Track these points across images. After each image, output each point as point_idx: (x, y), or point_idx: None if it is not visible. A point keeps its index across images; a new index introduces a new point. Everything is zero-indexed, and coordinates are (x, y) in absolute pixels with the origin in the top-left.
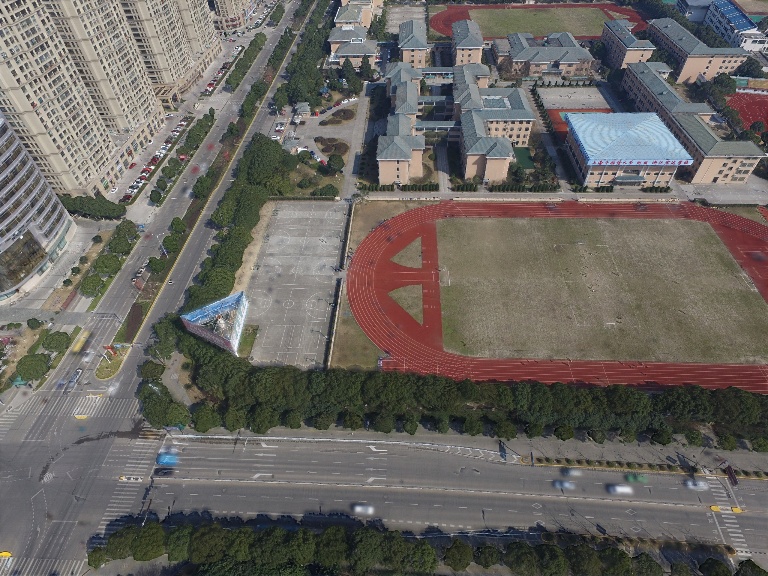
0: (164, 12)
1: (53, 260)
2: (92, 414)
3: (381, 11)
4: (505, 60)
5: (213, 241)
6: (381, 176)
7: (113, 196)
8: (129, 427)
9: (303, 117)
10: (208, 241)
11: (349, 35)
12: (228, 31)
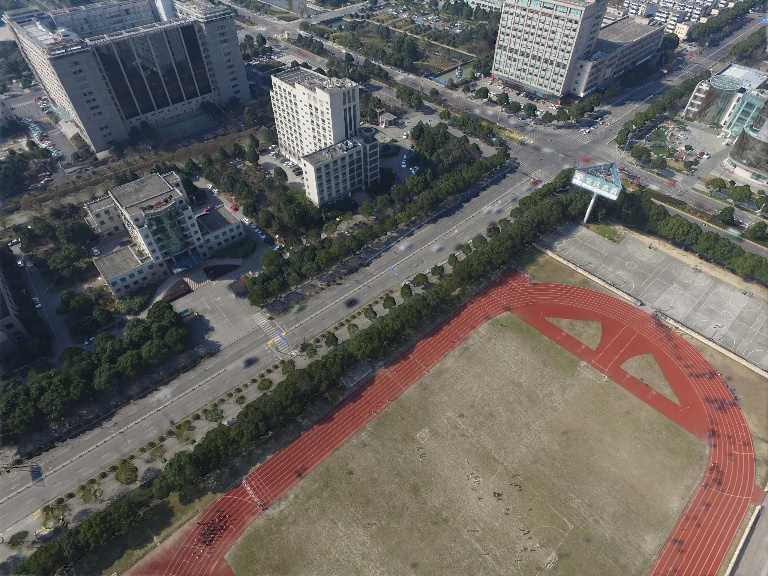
0: None
1: None
2: None
3: None
4: None
5: None
6: None
7: None
8: None
9: None
10: None
11: None
12: None
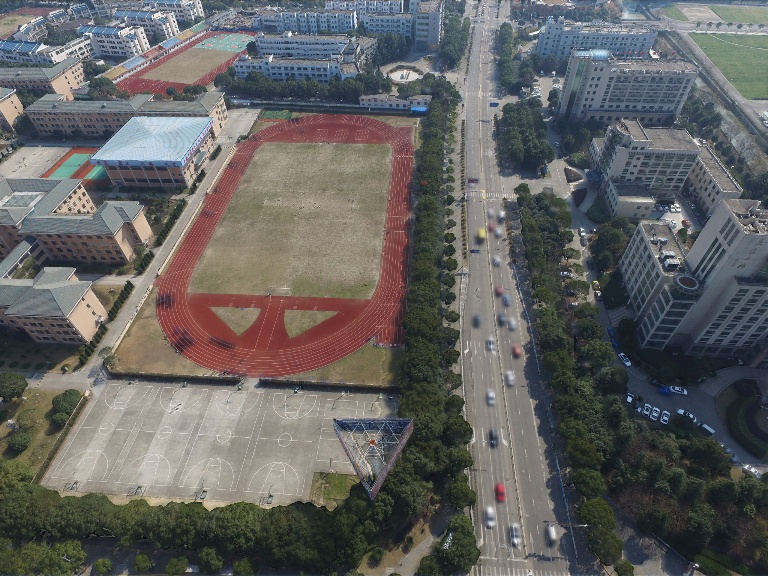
0: None
1: None
2: None
3: None
4: None
5: None
6: (81, 331)
7: None
8: None
9: None
10: None
11: None
12: None
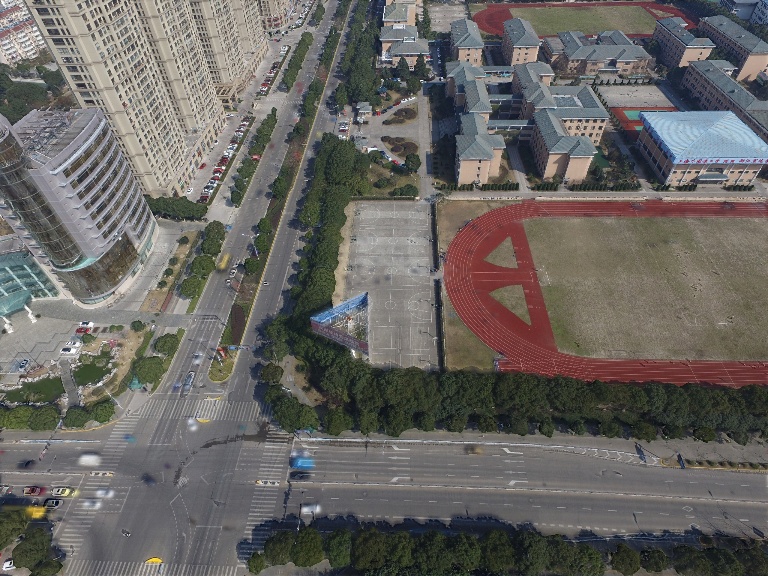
0: (224, 11)
1: (142, 261)
2: (214, 417)
3: (421, 10)
4: (560, 58)
5: (300, 242)
6: (461, 175)
7: (189, 197)
8: (254, 430)
9: (365, 116)
10: (295, 242)
11: (401, 34)
12: (270, 31)
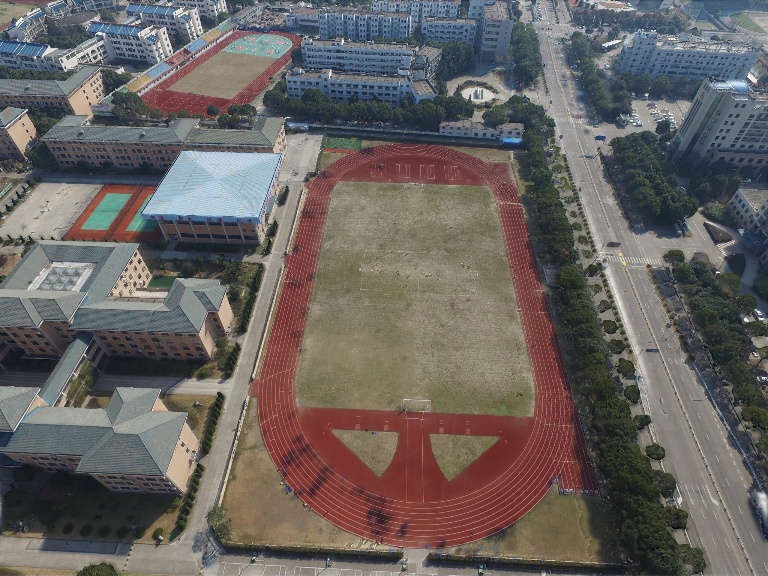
0: None
1: None
2: None
3: None
4: None
5: None
6: (177, 482)
7: None
8: None
9: None
10: None
11: None
12: None
